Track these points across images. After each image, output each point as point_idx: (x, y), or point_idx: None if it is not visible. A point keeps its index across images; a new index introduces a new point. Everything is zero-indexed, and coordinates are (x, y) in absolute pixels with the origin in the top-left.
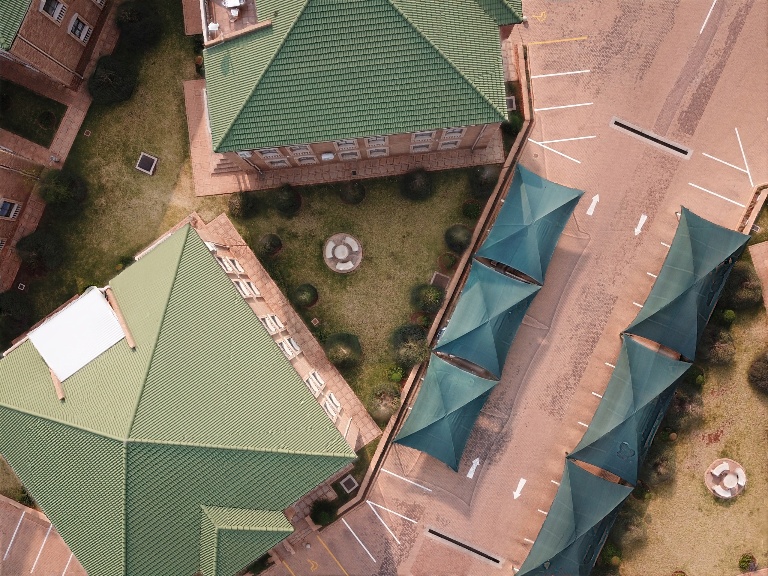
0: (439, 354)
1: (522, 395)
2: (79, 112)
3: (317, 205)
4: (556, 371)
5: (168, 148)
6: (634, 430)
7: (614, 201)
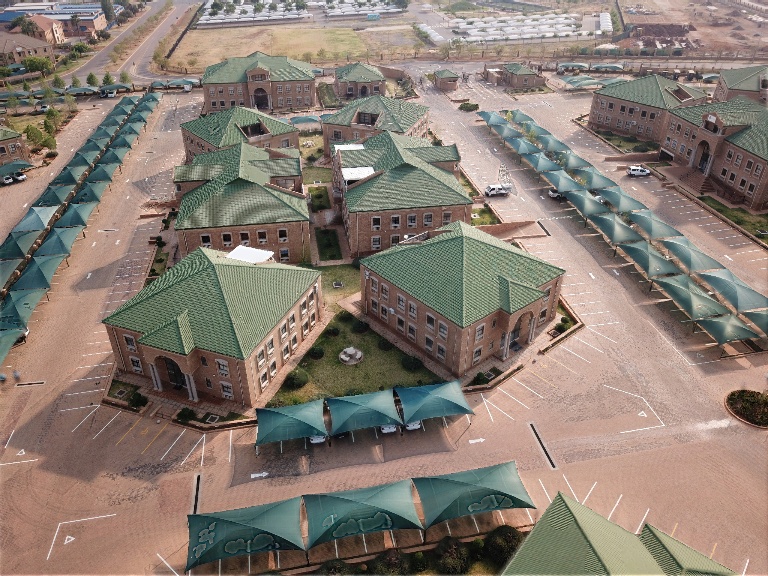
0: (325, 402)
1: (328, 473)
2: (343, 262)
3: (368, 338)
4: (358, 482)
5: (351, 287)
6: (349, 510)
7: (489, 449)
